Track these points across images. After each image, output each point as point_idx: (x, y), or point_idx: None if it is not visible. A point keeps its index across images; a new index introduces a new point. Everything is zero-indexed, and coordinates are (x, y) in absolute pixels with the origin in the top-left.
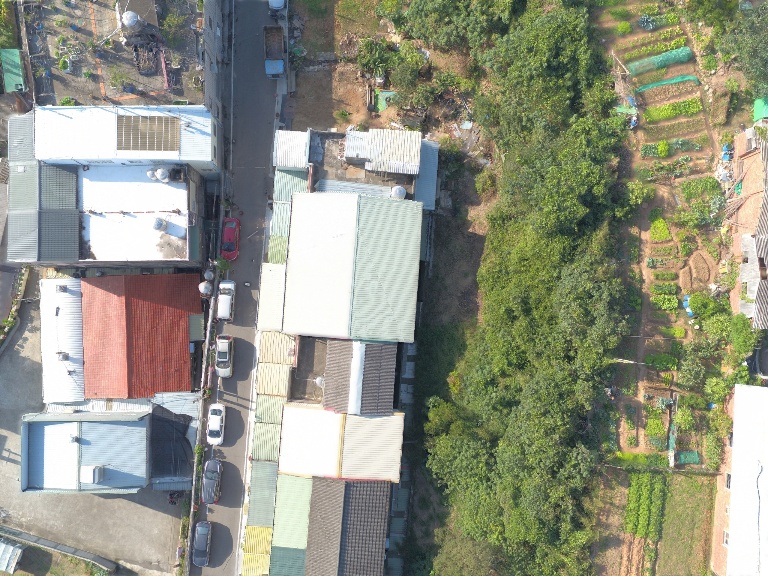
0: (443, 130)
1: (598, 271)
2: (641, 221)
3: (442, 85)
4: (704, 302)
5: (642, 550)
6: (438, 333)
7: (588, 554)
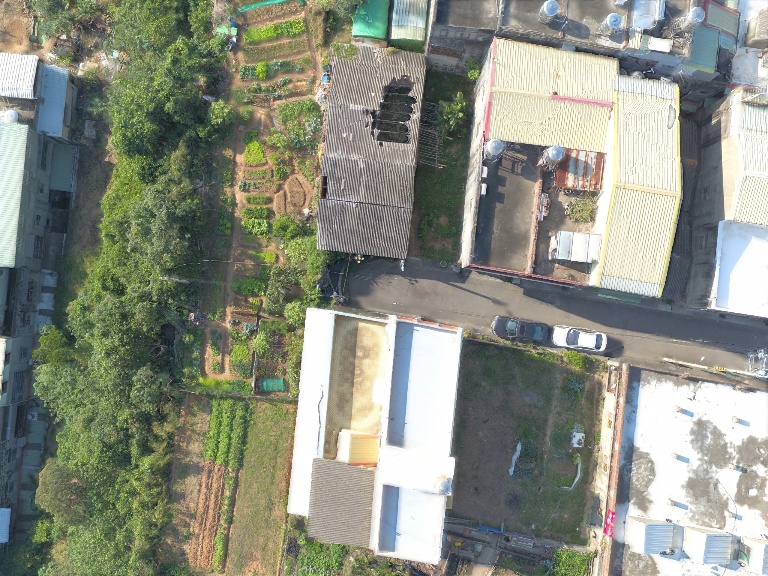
0: (94, 60)
1: (173, 191)
2: (237, 144)
3: (84, 12)
4: (284, 225)
5: (222, 478)
6: (68, 263)
7: (160, 480)
